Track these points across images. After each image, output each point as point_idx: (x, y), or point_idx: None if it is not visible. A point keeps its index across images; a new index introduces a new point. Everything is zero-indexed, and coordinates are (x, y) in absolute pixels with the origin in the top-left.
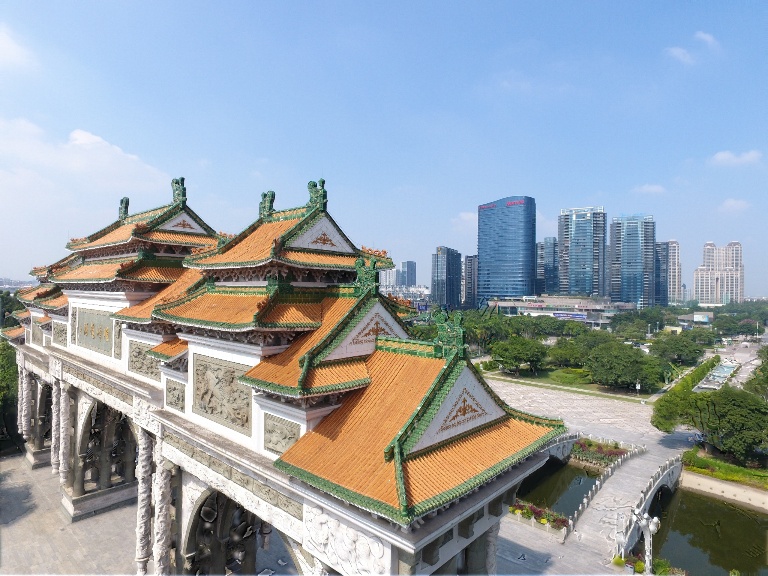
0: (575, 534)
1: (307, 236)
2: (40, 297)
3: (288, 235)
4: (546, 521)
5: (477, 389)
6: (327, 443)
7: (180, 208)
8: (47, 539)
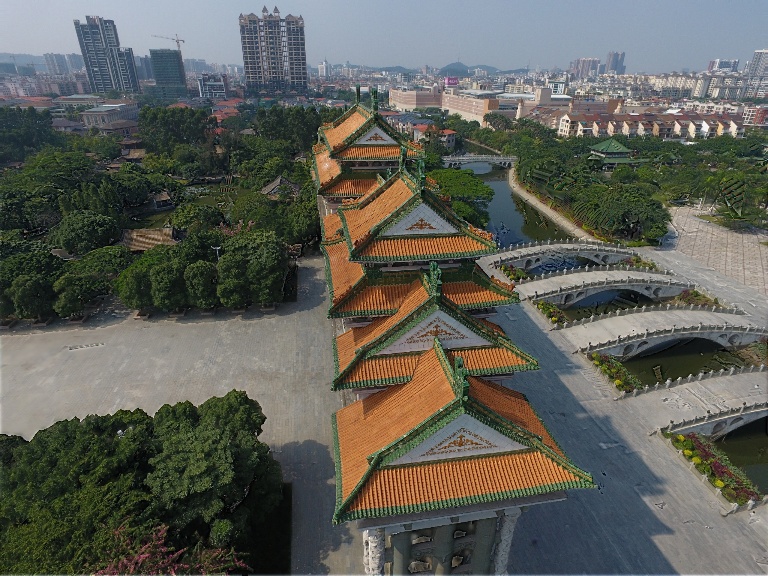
0: (750, 515)
1: (402, 224)
2: None
3: (384, 223)
4: (722, 485)
5: (483, 429)
6: (360, 419)
7: (373, 121)
8: (323, 330)
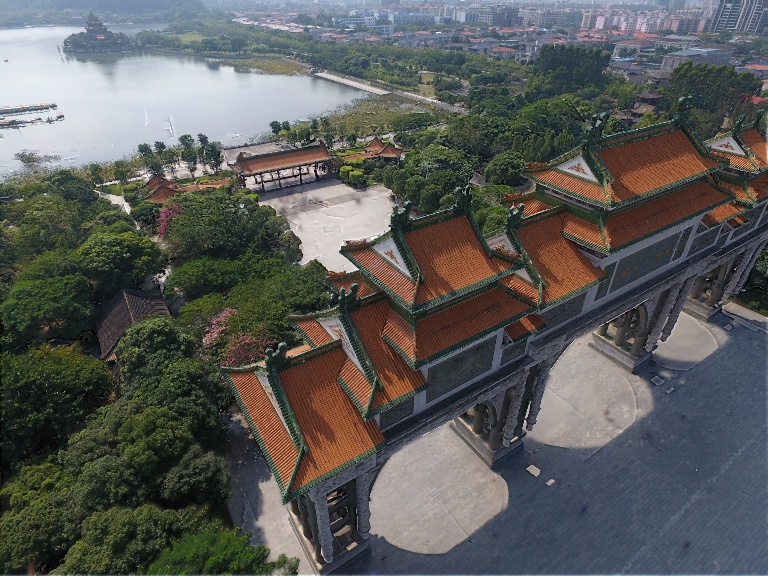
0: None
1: (382, 247)
2: None
3: (379, 240)
4: None
5: None
6: None
7: None
8: None
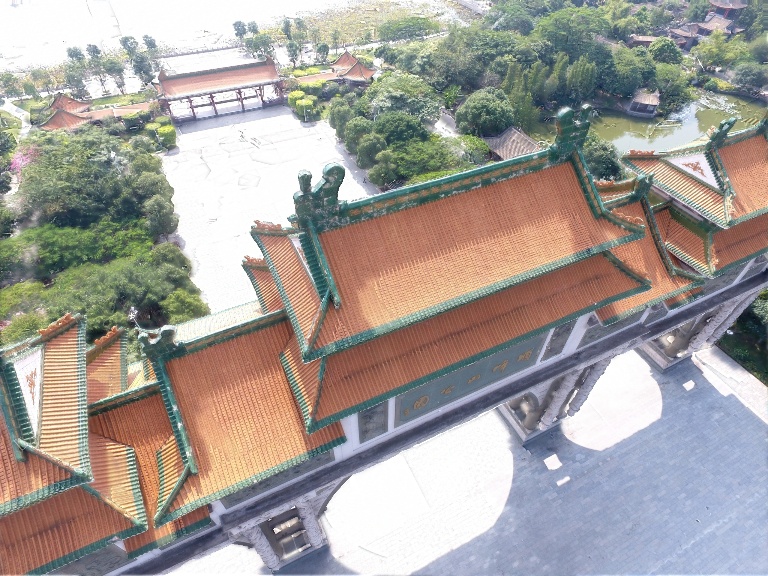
0: None
1: None
2: (597, 188)
3: None
4: None
5: None
6: None
7: None
8: None
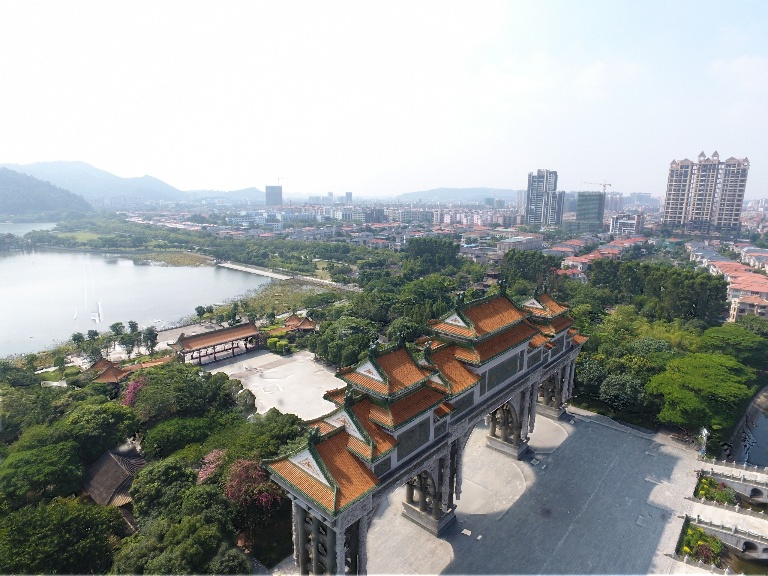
0: None
1: (362, 368)
2: None
3: None
4: None
5: None
6: None
7: None
8: (470, 446)
